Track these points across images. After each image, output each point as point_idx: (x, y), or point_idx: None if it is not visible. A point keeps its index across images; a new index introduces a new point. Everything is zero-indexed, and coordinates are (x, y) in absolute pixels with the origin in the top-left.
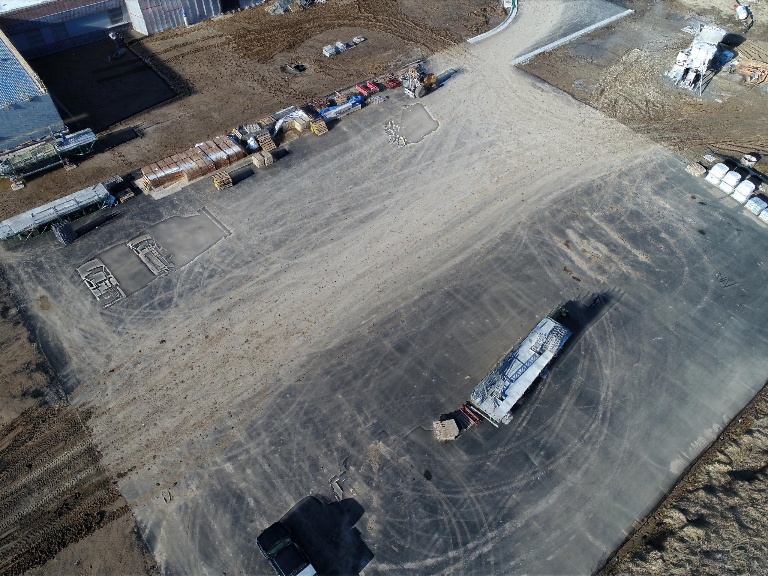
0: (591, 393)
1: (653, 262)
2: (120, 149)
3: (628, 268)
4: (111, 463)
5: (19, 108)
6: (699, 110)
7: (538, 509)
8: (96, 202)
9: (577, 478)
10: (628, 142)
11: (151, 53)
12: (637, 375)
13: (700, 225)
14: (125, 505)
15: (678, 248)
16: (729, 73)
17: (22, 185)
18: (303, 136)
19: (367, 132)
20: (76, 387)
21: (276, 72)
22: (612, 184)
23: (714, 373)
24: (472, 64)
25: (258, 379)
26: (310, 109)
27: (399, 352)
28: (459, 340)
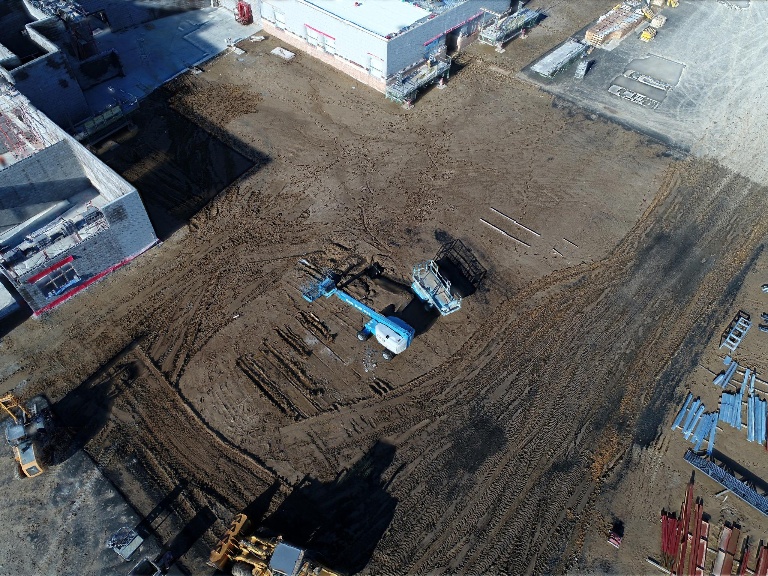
0: None
1: None
2: (544, 24)
3: None
4: (759, 180)
5: None
6: None
7: None
8: (582, 51)
9: None
10: None
11: None
12: None
13: None
14: None
15: None
16: None
17: (503, 49)
18: (664, 9)
19: (706, 3)
20: (690, 148)
21: None
22: None
23: None
24: None
25: None
26: None
27: None
28: None
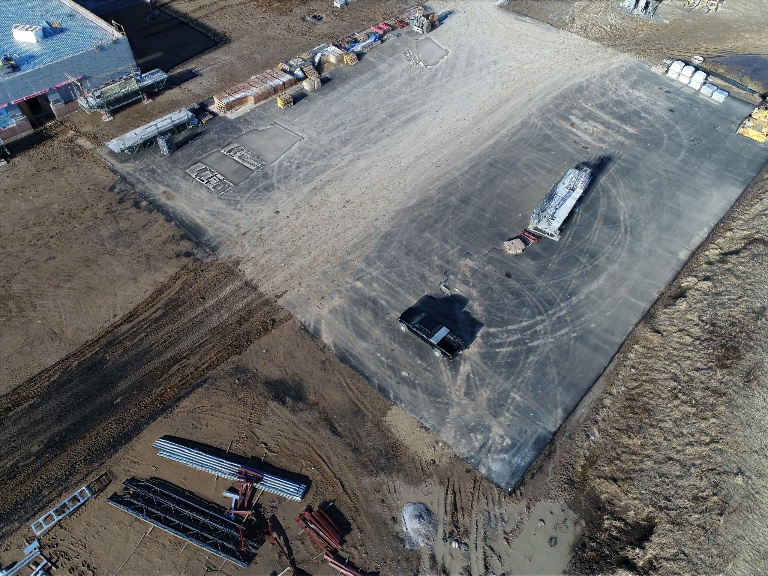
0: (613, 217)
1: (640, 133)
2: (186, 86)
3: (622, 138)
4: (268, 290)
5: (104, 50)
6: (652, 29)
7: (593, 287)
8: (185, 122)
9: (615, 267)
10: (602, 54)
11: (183, 13)
12: (644, 203)
13: (669, 106)
14: (289, 314)
15: (656, 122)
16: (670, 1)
17: (111, 117)
18: (339, 67)
19: (391, 60)
20: (219, 246)
21: (298, 21)
22: (597, 83)
23: (698, 198)
24: (463, 6)
25: (362, 229)
26: (338, 46)
27: (464, 204)
28: (507, 193)
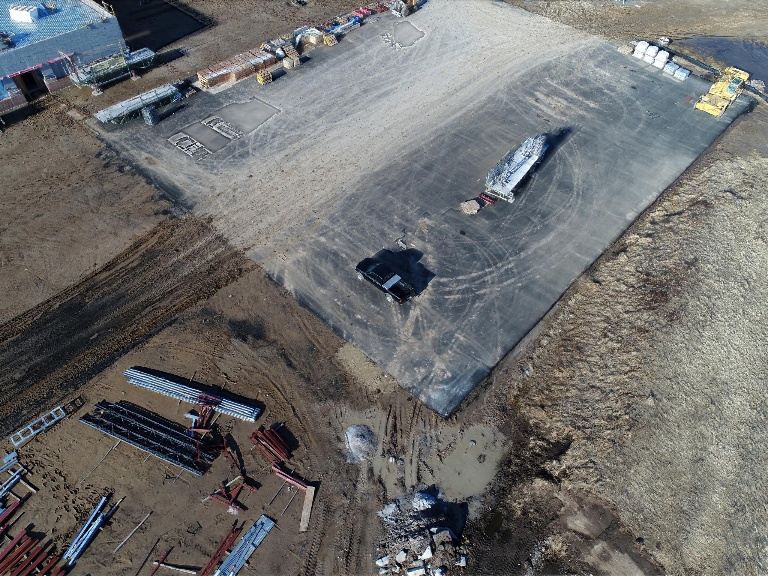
0: (567, 182)
1: (601, 107)
2: (172, 64)
3: (583, 112)
4: (237, 243)
5: (94, 28)
6: (624, 13)
7: (541, 244)
8: (169, 95)
9: (564, 226)
10: (572, 36)
11: None
12: (598, 171)
13: (632, 84)
14: (255, 264)
15: (618, 98)
16: None
17: (101, 92)
18: (318, 47)
19: (369, 42)
20: (195, 206)
21: (283, 6)
22: (564, 63)
23: (650, 166)
24: None
25: (328, 191)
26: (319, 29)
27: (427, 170)
28: (469, 160)
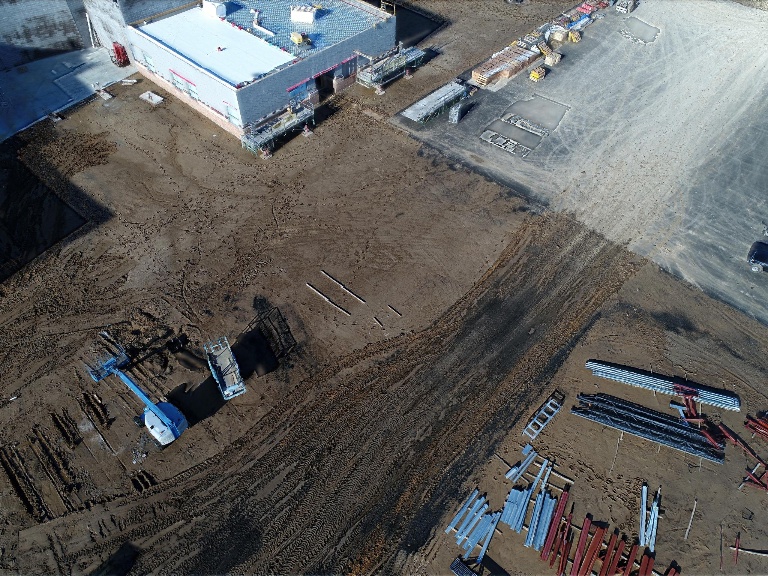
0: None
1: None
2: (434, 63)
3: None
4: (613, 238)
5: (379, 28)
6: None
7: None
8: (461, 94)
9: None
10: None
11: None
12: None
13: None
14: (643, 258)
15: None
16: None
17: (383, 91)
18: (565, 44)
19: (610, 38)
20: (549, 202)
21: (503, 4)
22: None
23: None
24: None
25: (669, 186)
26: None
27: (749, 163)
28: None
